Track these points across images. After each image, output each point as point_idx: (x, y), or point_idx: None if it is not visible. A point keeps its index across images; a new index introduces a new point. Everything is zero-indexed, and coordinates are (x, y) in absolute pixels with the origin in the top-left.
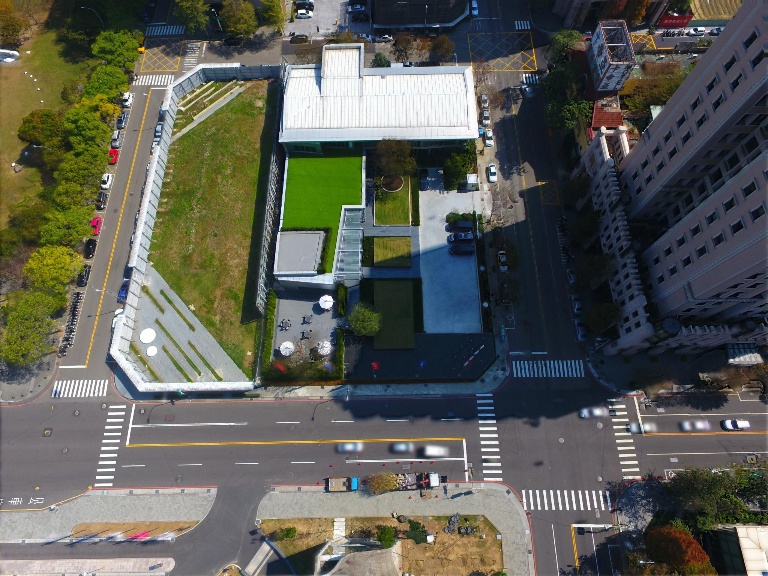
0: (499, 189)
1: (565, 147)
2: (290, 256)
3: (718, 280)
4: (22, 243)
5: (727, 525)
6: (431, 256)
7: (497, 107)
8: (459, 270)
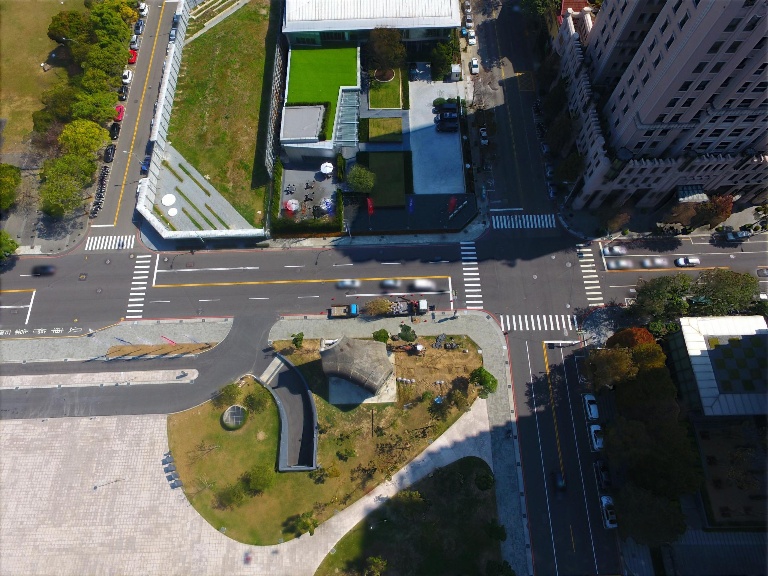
0: (481, 79)
1: (540, 42)
2: (294, 126)
3: (658, 96)
4: (56, 119)
5: None
6: (420, 133)
7: (479, 13)
8: (445, 144)
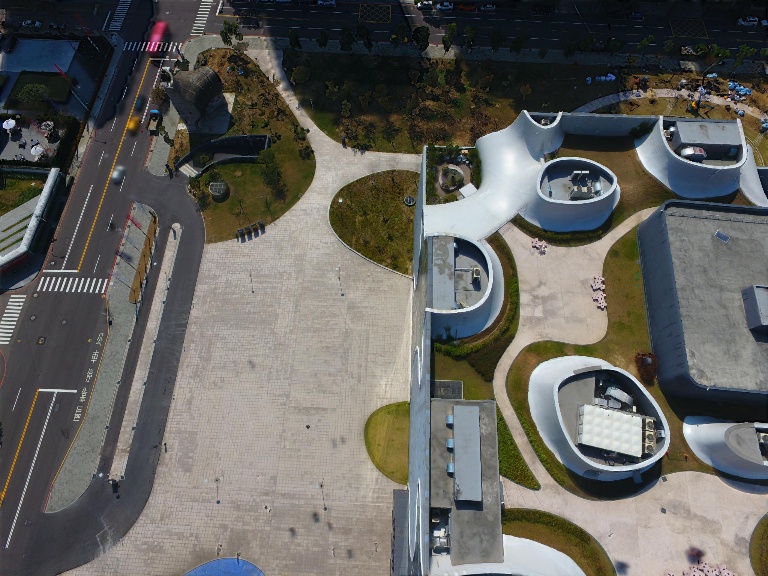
0: None
1: None
2: None
3: None
4: None
5: None
6: (6, 64)
7: None
8: (26, 49)
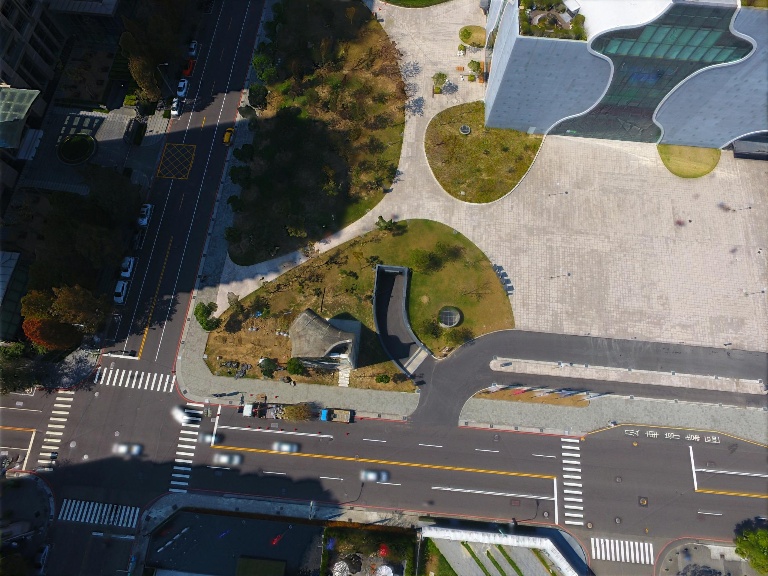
0: None
1: None
2: None
3: None
4: None
5: (4, 345)
6: None
7: None
8: None
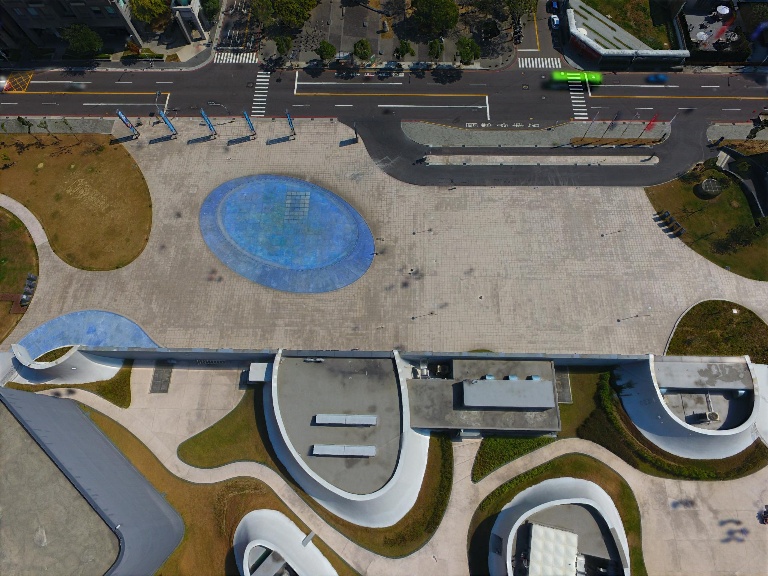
0: None
1: None
2: None
3: None
4: None
5: None
6: None
7: None
8: None
